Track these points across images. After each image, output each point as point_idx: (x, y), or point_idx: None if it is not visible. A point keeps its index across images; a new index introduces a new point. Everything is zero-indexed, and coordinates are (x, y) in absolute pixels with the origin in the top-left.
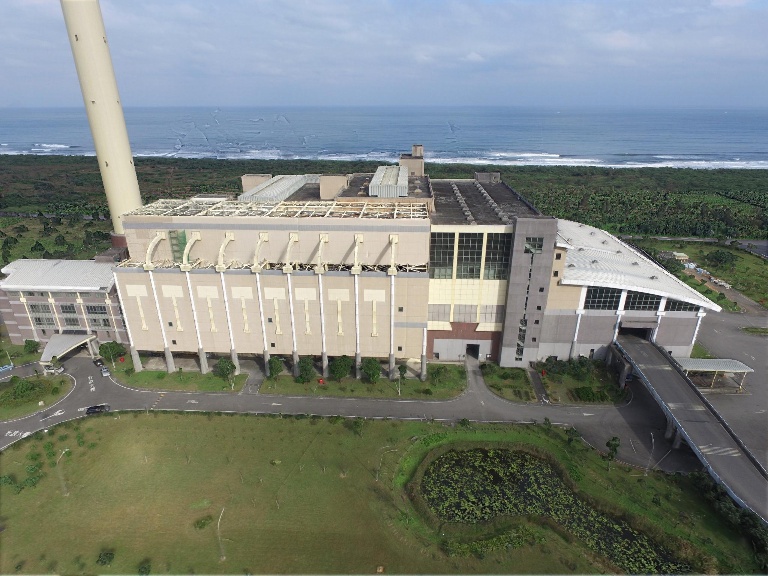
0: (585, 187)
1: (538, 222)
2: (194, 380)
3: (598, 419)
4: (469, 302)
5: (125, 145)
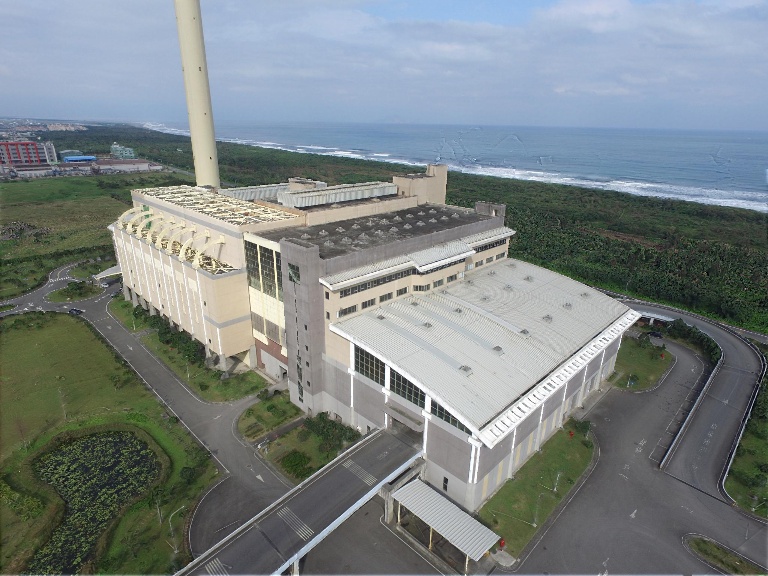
0: None
1: (293, 248)
2: None
3: (257, 487)
4: (273, 320)
5: (207, 145)
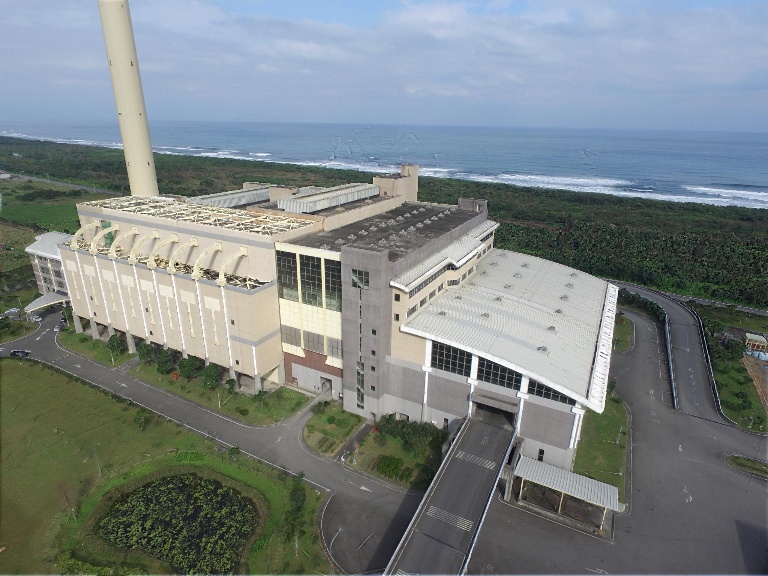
0: (745, 235)
1: (361, 253)
2: (99, 349)
3: (369, 498)
4: (316, 331)
5: (144, 149)
